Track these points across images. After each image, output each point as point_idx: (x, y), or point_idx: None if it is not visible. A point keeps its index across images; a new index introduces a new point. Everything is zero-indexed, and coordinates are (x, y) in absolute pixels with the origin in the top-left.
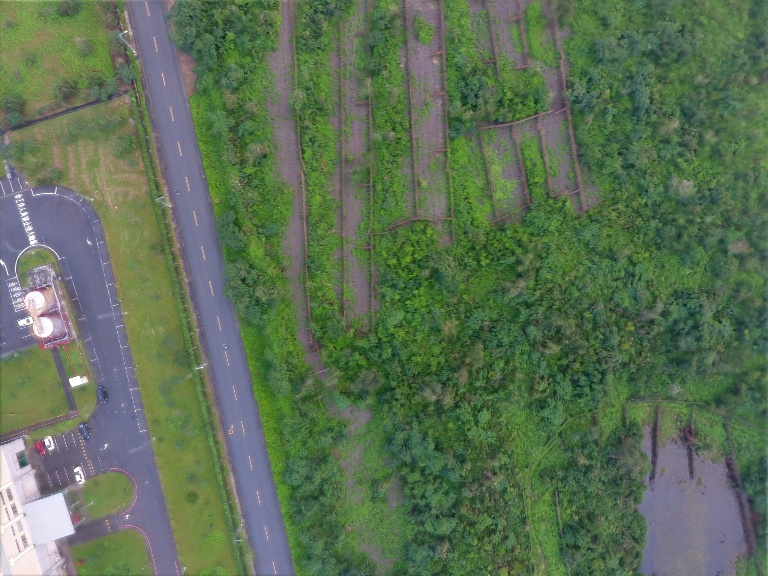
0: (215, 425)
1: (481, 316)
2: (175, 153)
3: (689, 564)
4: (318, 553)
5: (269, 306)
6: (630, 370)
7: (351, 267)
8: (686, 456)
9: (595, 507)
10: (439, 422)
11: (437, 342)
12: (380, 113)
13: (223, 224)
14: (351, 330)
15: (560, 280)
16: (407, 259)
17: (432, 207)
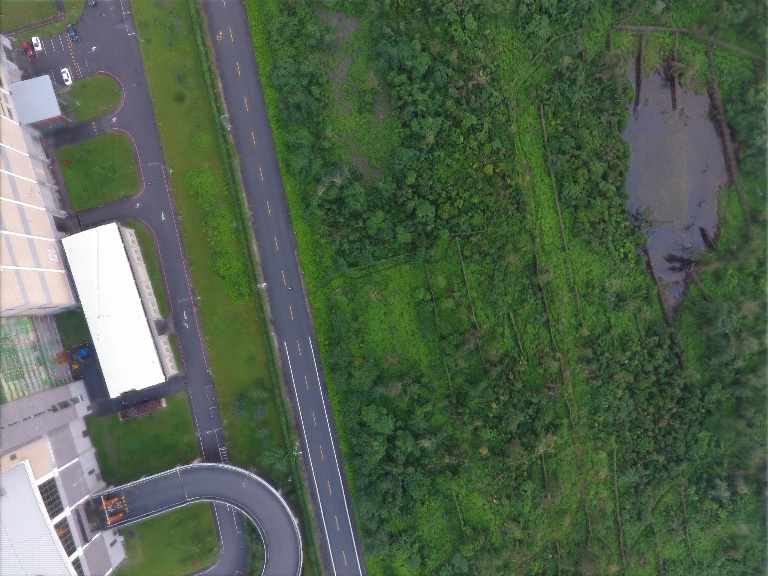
0: (203, 29)
1: None
2: None
3: (672, 193)
4: (305, 153)
5: None
6: None
7: None
8: (669, 89)
9: (579, 120)
10: (426, 28)
11: None
12: None
13: None
14: None
15: None
16: None
17: None
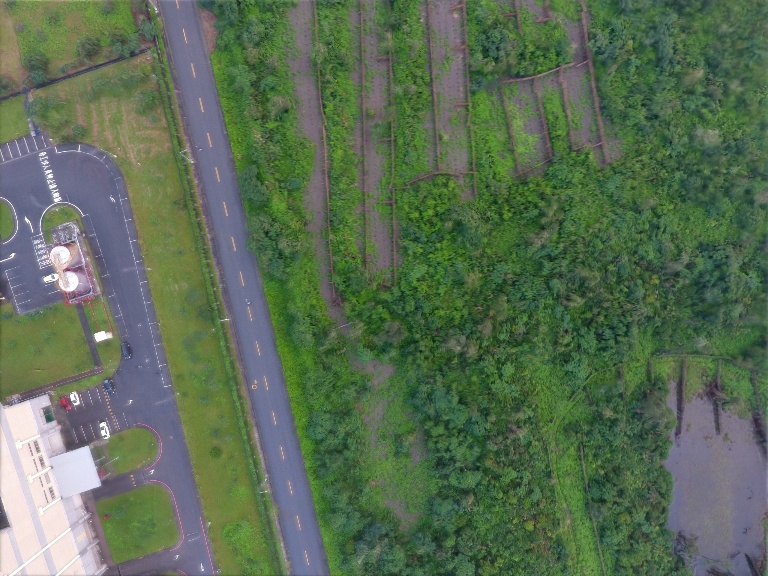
0: (239, 380)
1: (504, 269)
2: (197, 109)
3: (716, 521)
4: (342, 507)
5: (292, 260)
6: (655, 324)
7: (373, 222)
8: (712, 412)
9: (621, 461)
10: (463, 376)
11: (460, 296)
12: (401, 68)
13: (246, 178)
14: (374, 283)
15: (584, 233)
16: (429, 212)
17: (454, 161)
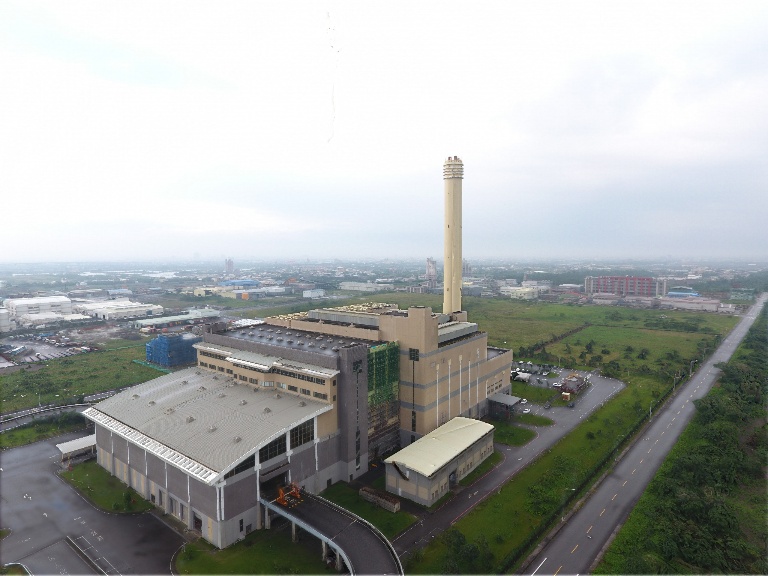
0: (636, 432)
1: None
2: None
3: None
4: None
5: None
6: None
7: None
8: None
9: None
10: None
11: None
12: None
13: (710, 396)
14: None
15: None
16: None
17: None
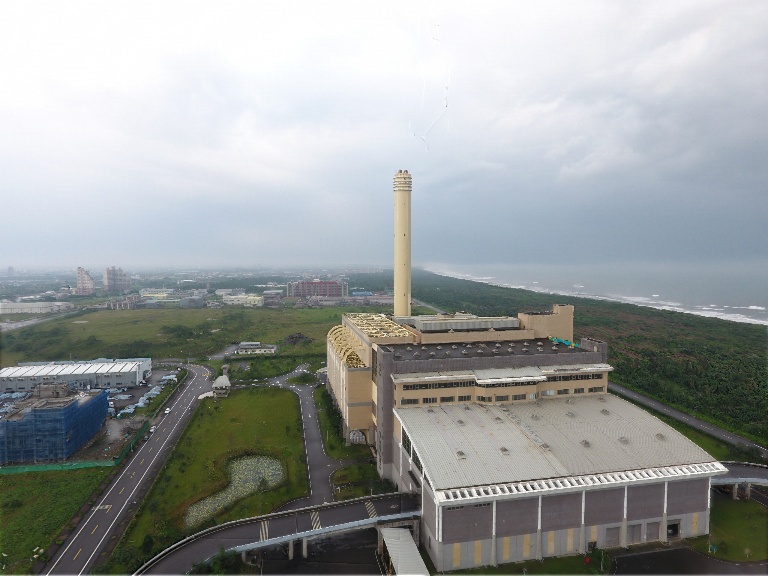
0: None
1: None
2: None
3: None
4: None
5: None
6: None
7: None
8: None
9: None
10: None
11: None
12: None
13: None
14: None
15: None
16: (646, 360)
17: None
